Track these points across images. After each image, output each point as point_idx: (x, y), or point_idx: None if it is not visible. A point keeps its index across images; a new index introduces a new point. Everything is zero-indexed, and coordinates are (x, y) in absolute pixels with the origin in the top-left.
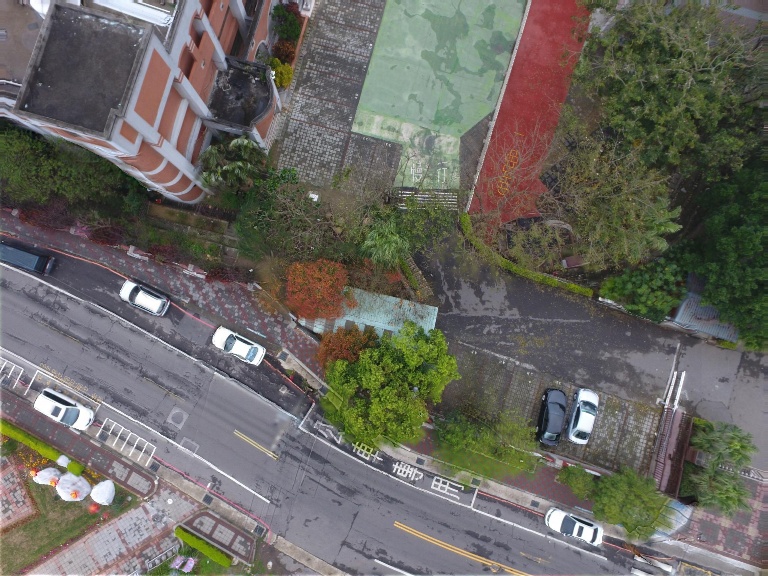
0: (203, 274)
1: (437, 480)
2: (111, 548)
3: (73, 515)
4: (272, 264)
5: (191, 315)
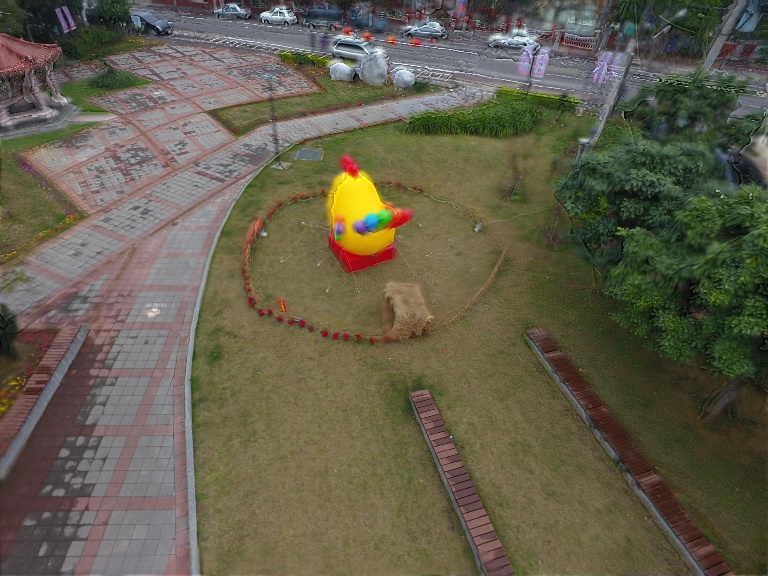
0: (471, 31)
1: (761, 93)
2: (416, 110)
3: (368, 95)
4: (538, 1)
5: (464, 44)
